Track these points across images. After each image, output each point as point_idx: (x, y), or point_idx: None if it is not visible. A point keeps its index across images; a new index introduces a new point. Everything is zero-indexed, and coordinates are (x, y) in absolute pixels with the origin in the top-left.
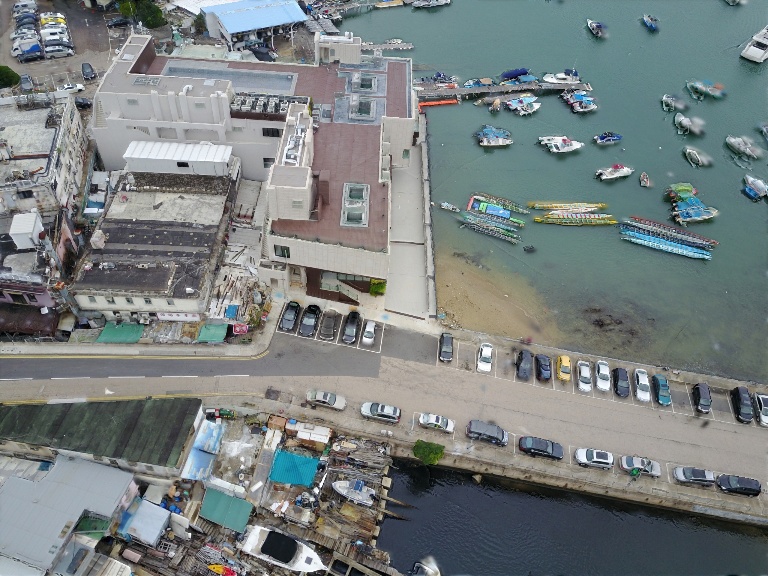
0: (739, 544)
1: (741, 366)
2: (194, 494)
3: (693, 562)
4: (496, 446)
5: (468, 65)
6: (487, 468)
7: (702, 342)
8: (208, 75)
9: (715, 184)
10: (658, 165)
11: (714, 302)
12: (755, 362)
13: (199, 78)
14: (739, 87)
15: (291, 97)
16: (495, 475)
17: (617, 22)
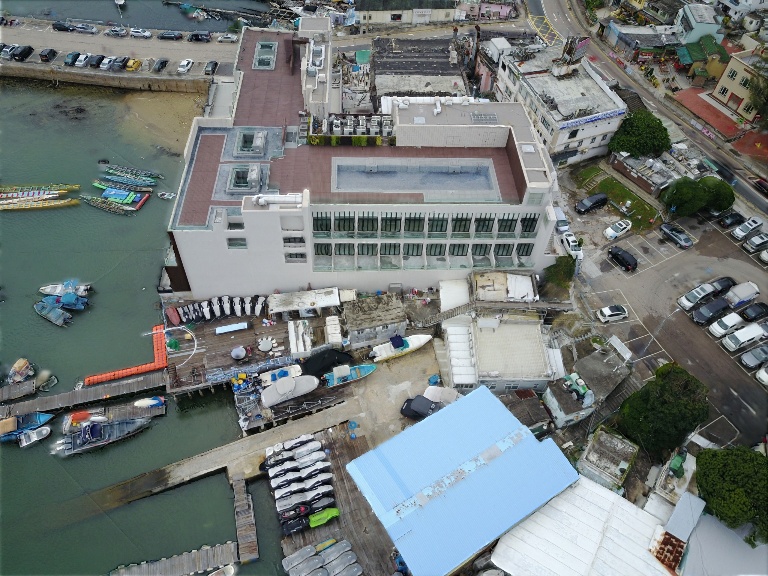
0: None
1: None
2: None
3: None
4: None
5: (3, 530)
6: None
7: (3, 104)
8: None
9: None
10: None
11: None
12: None
13: (433, 125)
14: None
15: None
16: None
17: None
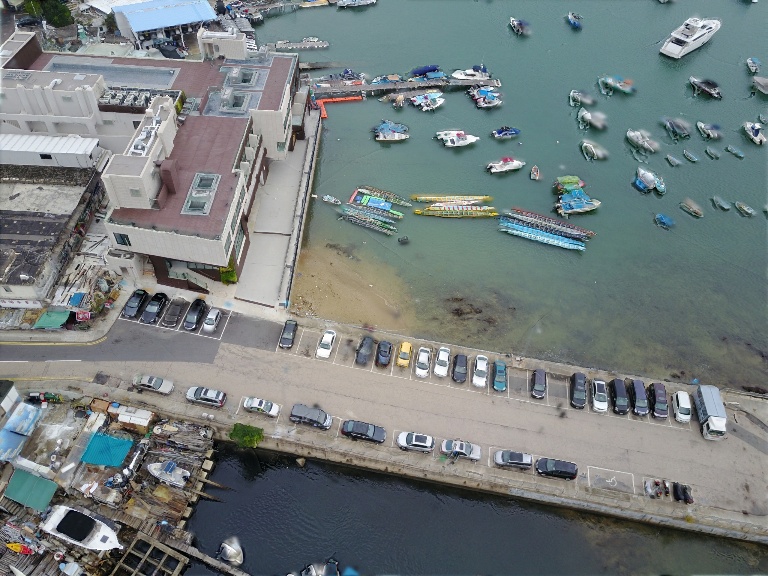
0: (555, 527)
1: (594, 354)
2: (4, 475)
3: (504, 544)
4: (319, 430)
5: (382, 62)
6: (309, 451)
7: (560, 331)
8: (92, 71)
9: (608, 177)
10: (553, 159)
11: (581, 292)
12: (609, 350)
13: (70, 73)
14: (654, 83)
15: (163, 91)
16: (319, 459)
17: (542, 20)
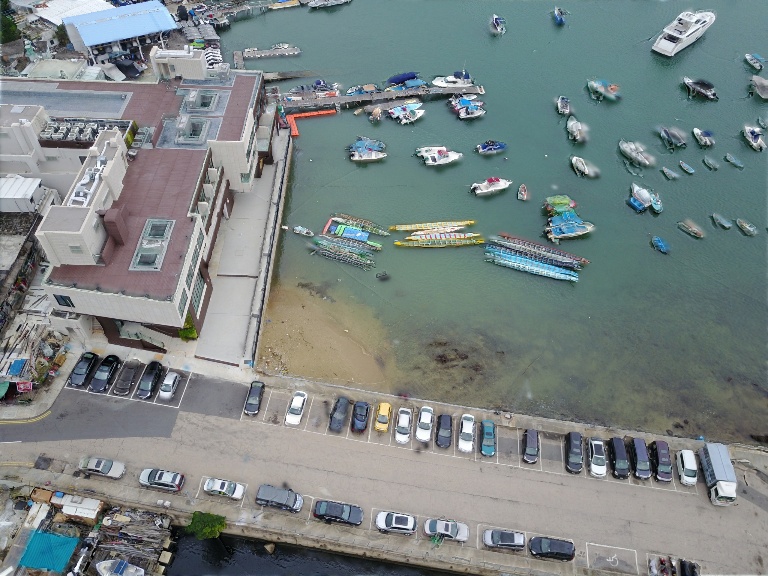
0: None
1: (590, 403)
2: None
3: None
4: (288, 512)
5: (357, 69)
6: (279, 537)
7: (552, 376)
8: (35, 97)
9: (601, 194)
10: (542, 175)
11: (574, 329)
12: (606, 398)
13: (7, 104)
14: (647, 84)
15: (112, 121)
16: (290, 544)
17: (526, 16)
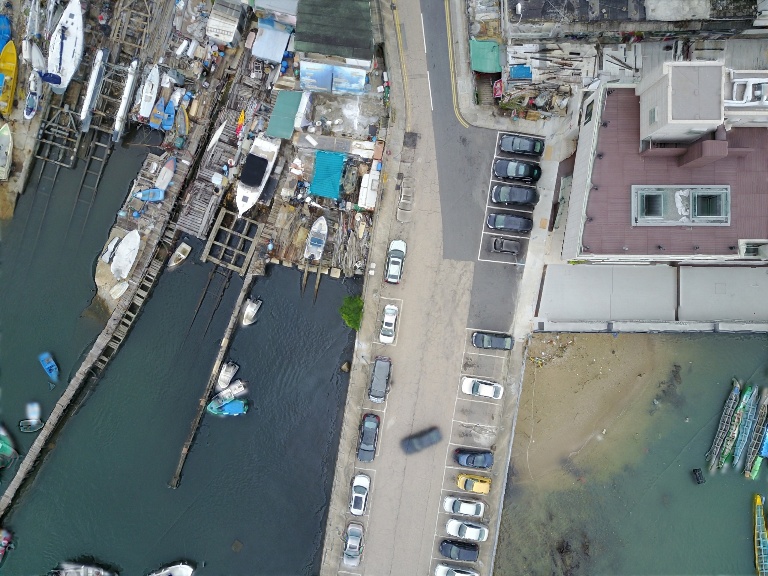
0: None
1: None
2: None
3: (274, 572)
4: None
5: None
6: None
7: None
8: None
9: None
10: None
11: None
12: None
13: None
14: None
15: None
16: None
17: None
